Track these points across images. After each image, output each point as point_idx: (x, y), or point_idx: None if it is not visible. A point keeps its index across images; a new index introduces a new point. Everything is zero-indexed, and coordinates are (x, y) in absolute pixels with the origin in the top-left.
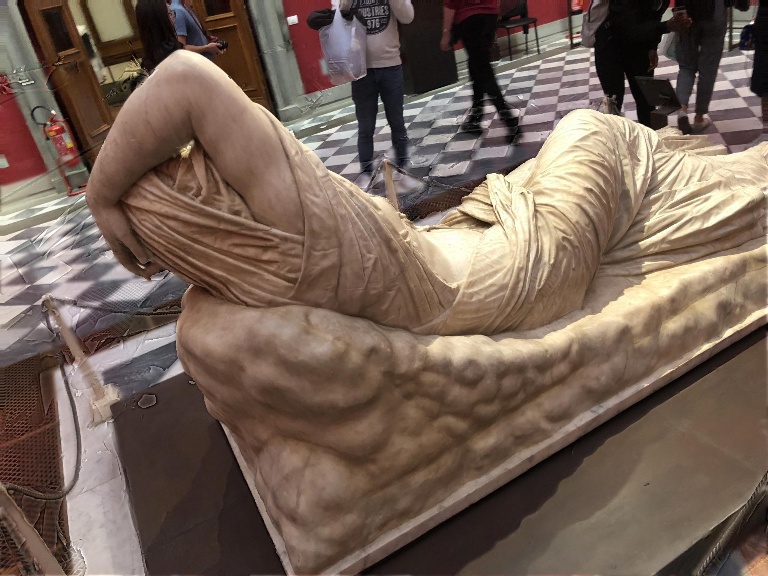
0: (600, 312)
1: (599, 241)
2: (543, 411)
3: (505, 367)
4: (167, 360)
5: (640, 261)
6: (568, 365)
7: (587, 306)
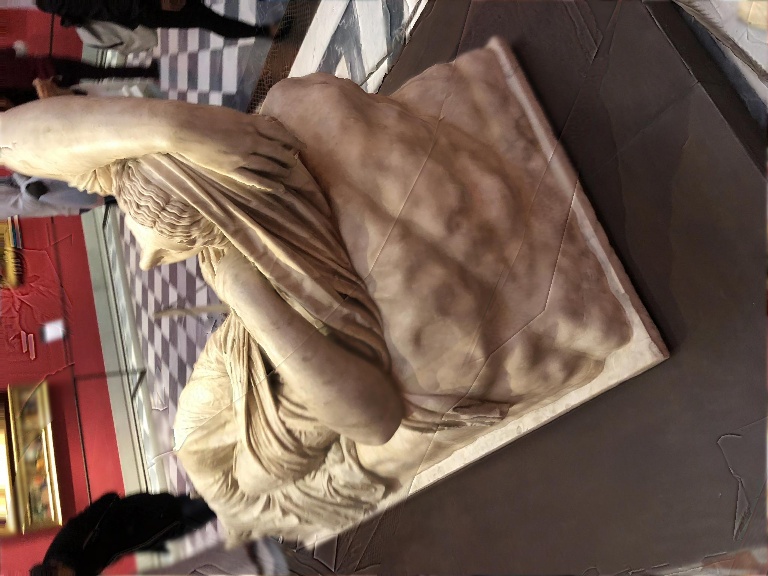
0: None
1: None
2: None
3: None
4: None
5: None
6: None
7: None
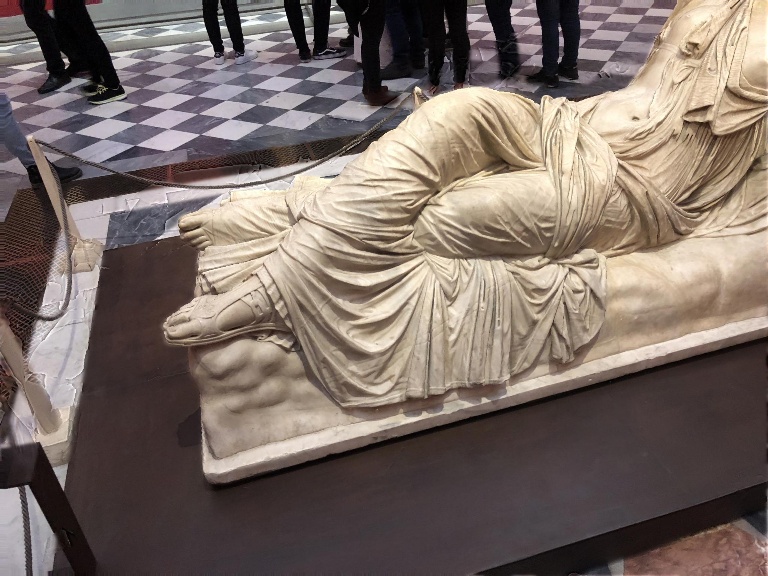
0: None
1: None
2: None
3: None
4: None
5: None
6: None
7: None
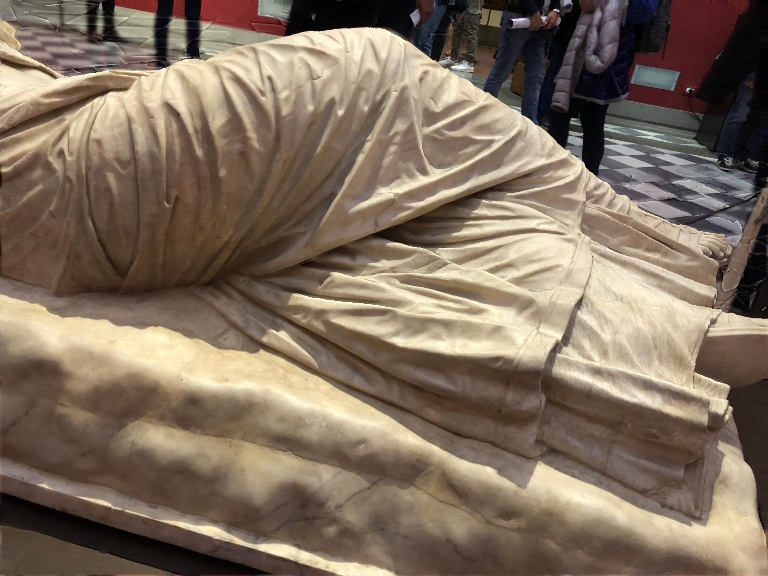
0: (62, 316)
1: (140, 207)
2: None
3: None
4: None
5: (279, 324)
6: None
7: (75, 299)
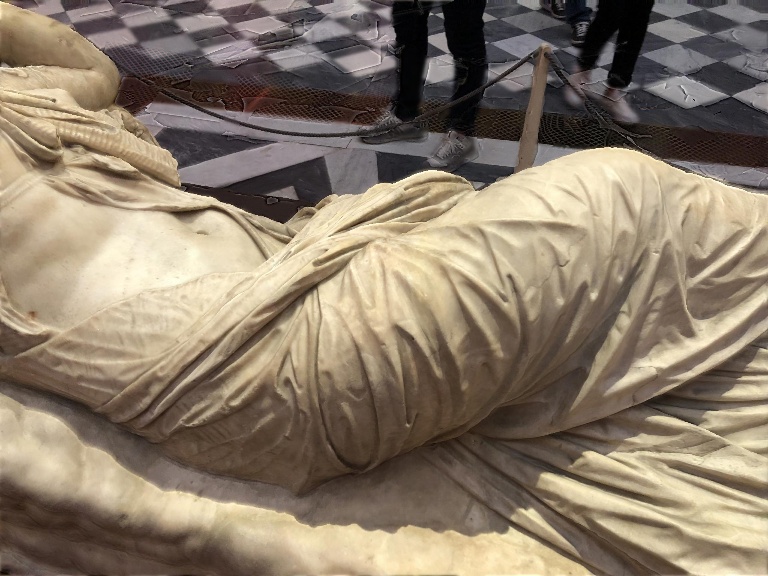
0: (313, 526)
1: (379, 428)
2: (121, 571)
3: (13, 494)
4: (209, 153)
5: (526, 499)
6: (177, 554)
7: (317, 497)
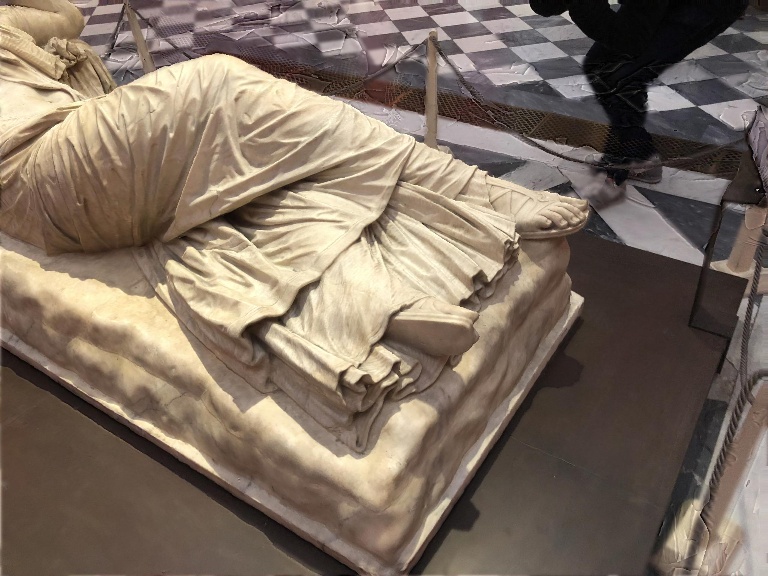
0: (46, 270)
1: (67, 206)
2: None
3: None
4: None
5: (166, 279)
6: None
7: (57, 258)
